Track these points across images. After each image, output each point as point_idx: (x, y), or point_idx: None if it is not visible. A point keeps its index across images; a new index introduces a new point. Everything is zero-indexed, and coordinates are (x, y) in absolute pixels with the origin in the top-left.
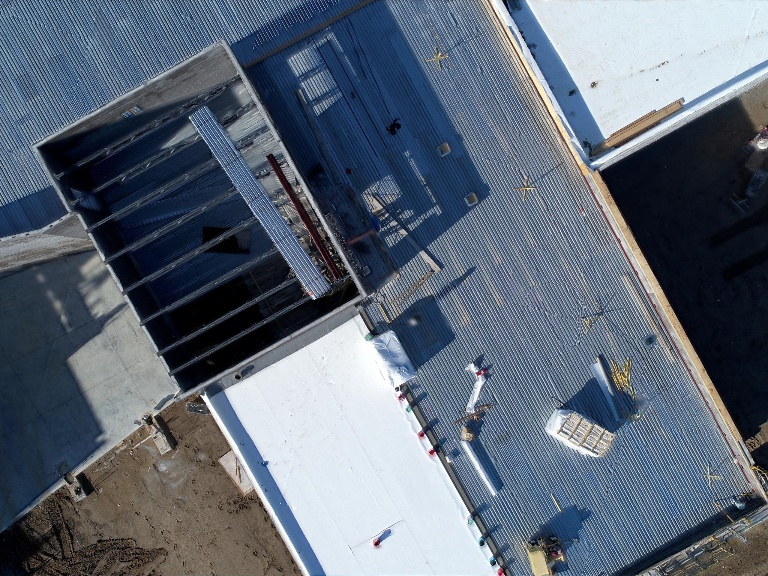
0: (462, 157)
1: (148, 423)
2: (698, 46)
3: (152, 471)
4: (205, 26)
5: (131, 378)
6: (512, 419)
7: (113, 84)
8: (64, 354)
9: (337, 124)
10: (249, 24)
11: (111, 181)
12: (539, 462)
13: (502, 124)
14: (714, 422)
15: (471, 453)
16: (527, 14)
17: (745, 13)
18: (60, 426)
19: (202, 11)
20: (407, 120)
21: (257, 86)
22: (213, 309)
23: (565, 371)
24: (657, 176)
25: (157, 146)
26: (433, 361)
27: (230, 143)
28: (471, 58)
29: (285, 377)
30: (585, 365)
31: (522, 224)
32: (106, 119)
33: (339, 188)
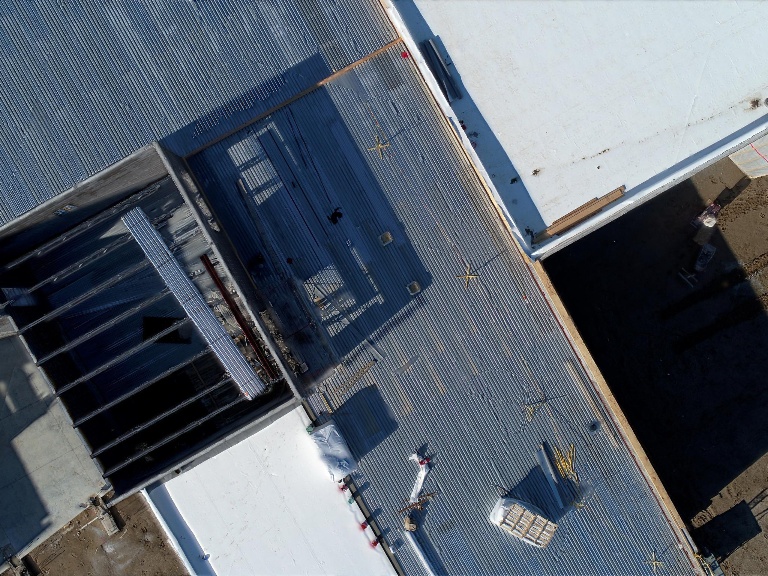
0: (404, 245)
1: (95, 504)
2: (639, 134)
3: (100, 552)
4: (144, 115)
5: (77, 459)
6: (456, 508)
7: (50, 174)
8: (9, 435)
9: (278, 213)
10: (189, 113)
11: (42, 283)
12: (484, 551)
13: (444, 212)
14: (659, 508)
15: (415, 544)
16: (468, 103)
17: (685, 101)
18: (5, 508)
19: (141, 100)
20: (348, 209)
21: (197, 176)
22: (154, 399)
23: (509, 459)
24: (606, 251)
25: (96, 235)
26: (376, 451)
27: (163, 244)
28: (412, 146)
29: (226, 469)
30: (529, 453)
31: (465, 312)
32: (37, 219)
33: (276, 285)
